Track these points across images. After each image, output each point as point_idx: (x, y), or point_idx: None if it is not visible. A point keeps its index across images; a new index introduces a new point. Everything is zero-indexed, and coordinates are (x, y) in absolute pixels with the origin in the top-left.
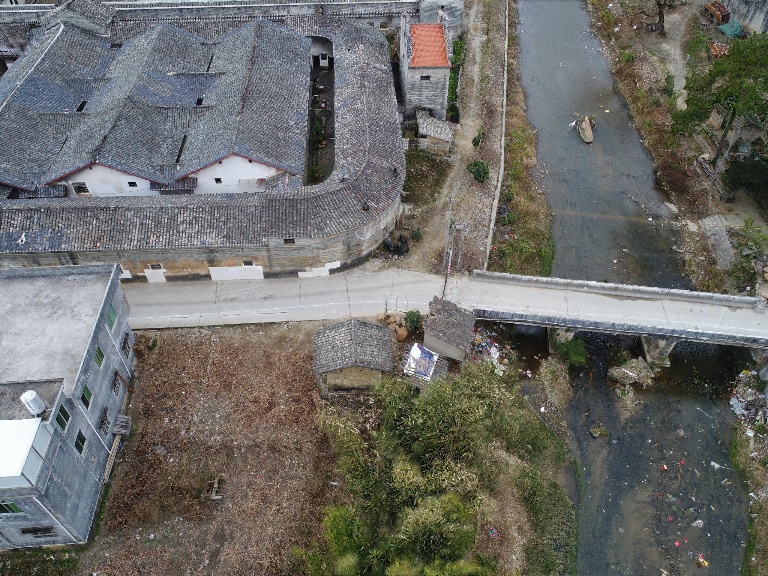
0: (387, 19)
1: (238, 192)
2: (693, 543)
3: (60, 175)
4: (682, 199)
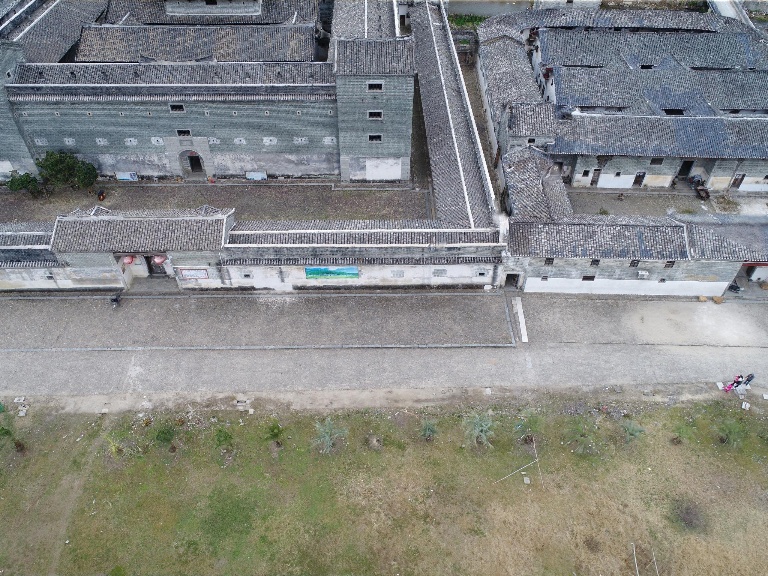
0: None
1: None
2: None
3: None
4: (605, 1)
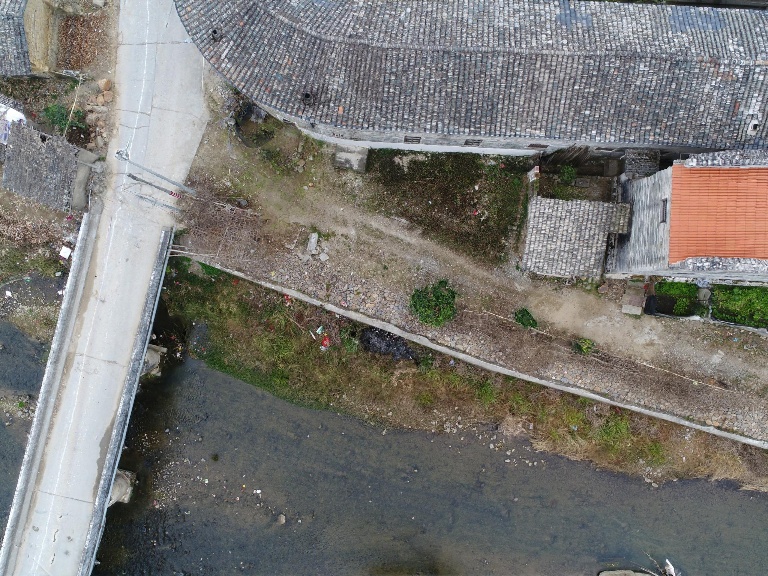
0: None
1: None
2: None
3: None
4: None
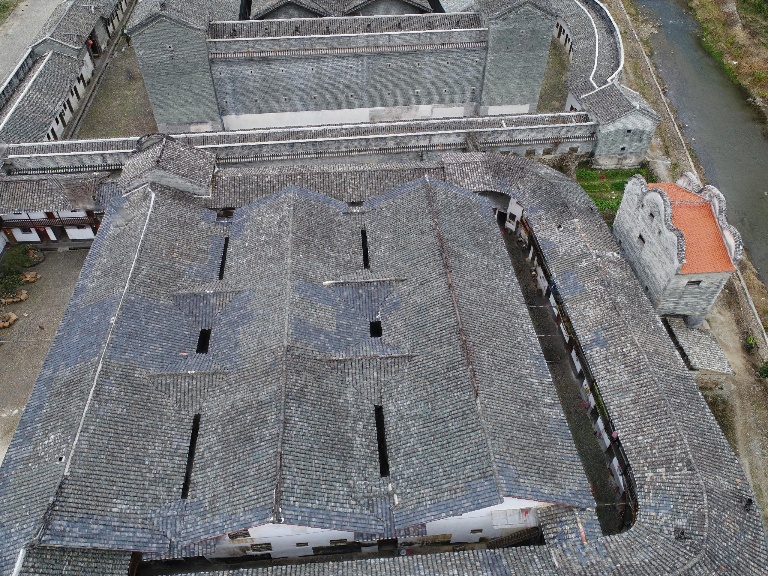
0: (553, 145)
1: (481, 521)
2: None
3: (215, 534)
4: None
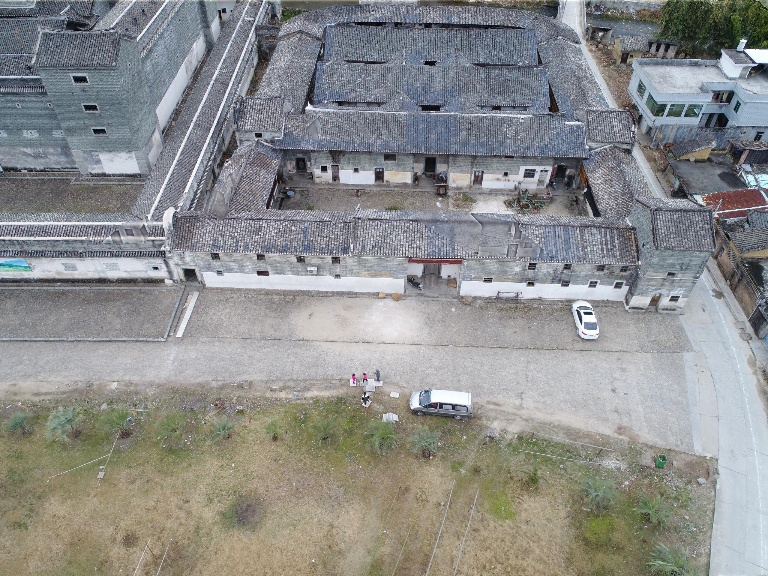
0: None
1: None
2: (657, 30)
3: None
4: None
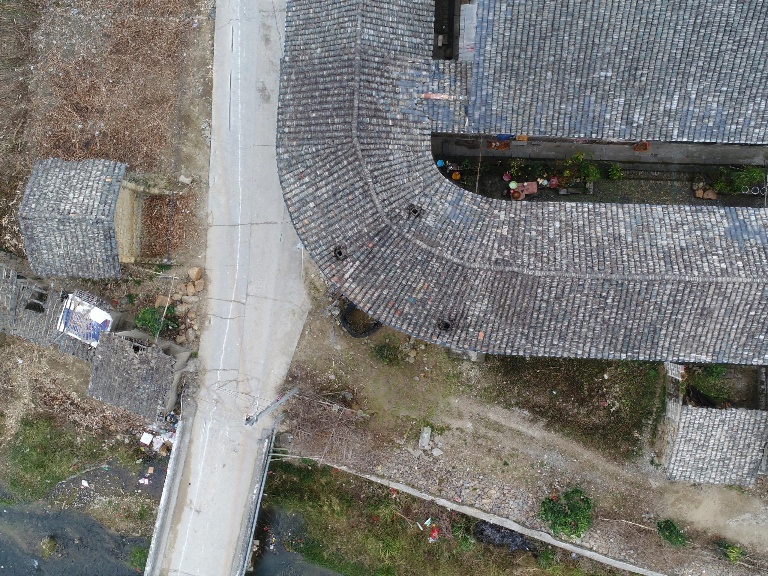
0: None
1: None
2: None
3: None
4: None
